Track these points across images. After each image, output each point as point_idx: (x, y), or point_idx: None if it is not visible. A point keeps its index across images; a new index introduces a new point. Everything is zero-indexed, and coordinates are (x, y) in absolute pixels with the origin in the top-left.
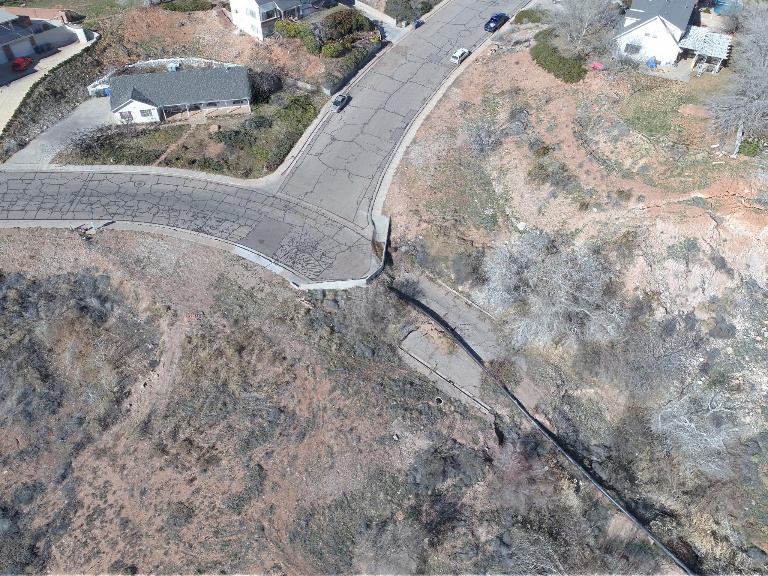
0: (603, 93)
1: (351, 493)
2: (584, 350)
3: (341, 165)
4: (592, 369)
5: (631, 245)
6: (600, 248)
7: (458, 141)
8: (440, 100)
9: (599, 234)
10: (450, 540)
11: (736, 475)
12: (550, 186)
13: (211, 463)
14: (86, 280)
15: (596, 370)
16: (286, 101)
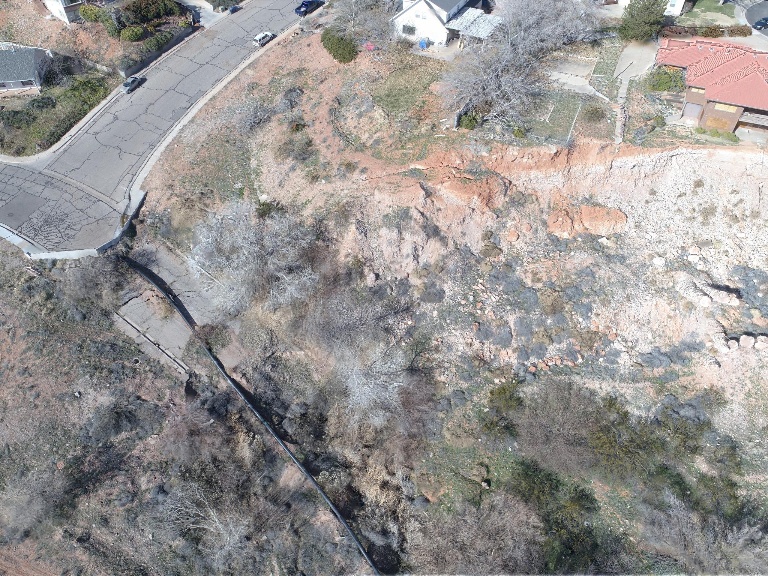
0: (367, 72)
1: (15, 444)
2: (294, 314)
3: (115, 143)
4: (297, 332)
5: (348, 214)
6: (324, 218)
7: (234, 120)
8: (230, 81)
9: (325, 205)
10: (106, 488)
11: (412, 429)
12: (292, 160)
13: None
14: None
15: (300, 332)
16: (77, 83)
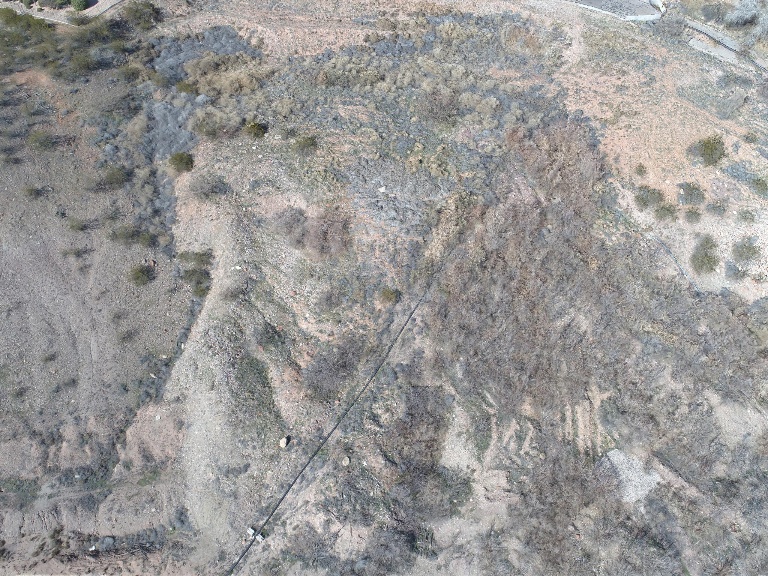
0: None
1: (696, 85)
2: None
3: None
4: None
5: None
6: None
7: None
8: None
9: None
10: (747, 105)
11: None
12: None
13: (625, 73)
14: (508, 16)
15: None
16: None
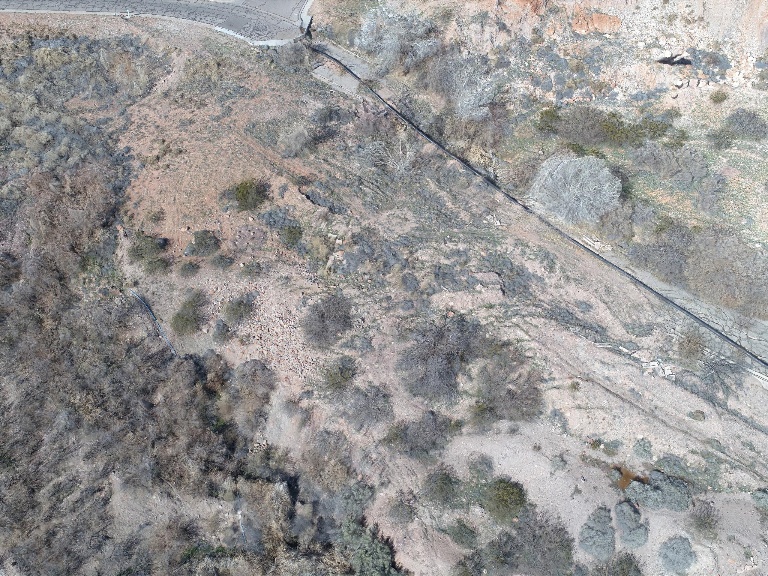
0: None
1: (278, 119)
2: (420, 73)
3: None
4: (423, 81)
5: (450, 16)
6: (434, 21)
7: None
8: None
9: (434, 14)
10: (331, 142)
11: None
12: None
13: (202, 105)
14: (126, 40)
15: (425, 81)
16: None
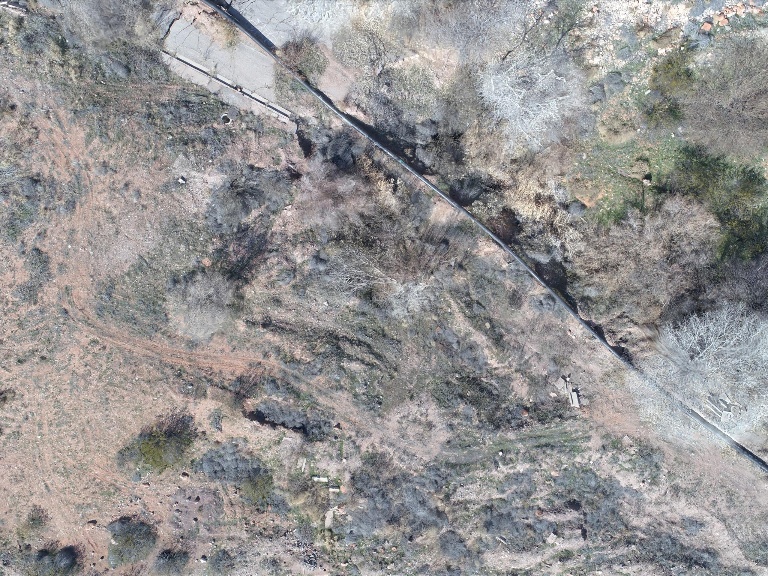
0: None
1: (148, 254)
2: (401, 7)
3: None
4: (411, 33)
5: None
6: None
7: None
8: None
9: None
10: (264, 273)
11: (568, 136)
12: None
13: None
14: None
15: (416, 34)
16: None
